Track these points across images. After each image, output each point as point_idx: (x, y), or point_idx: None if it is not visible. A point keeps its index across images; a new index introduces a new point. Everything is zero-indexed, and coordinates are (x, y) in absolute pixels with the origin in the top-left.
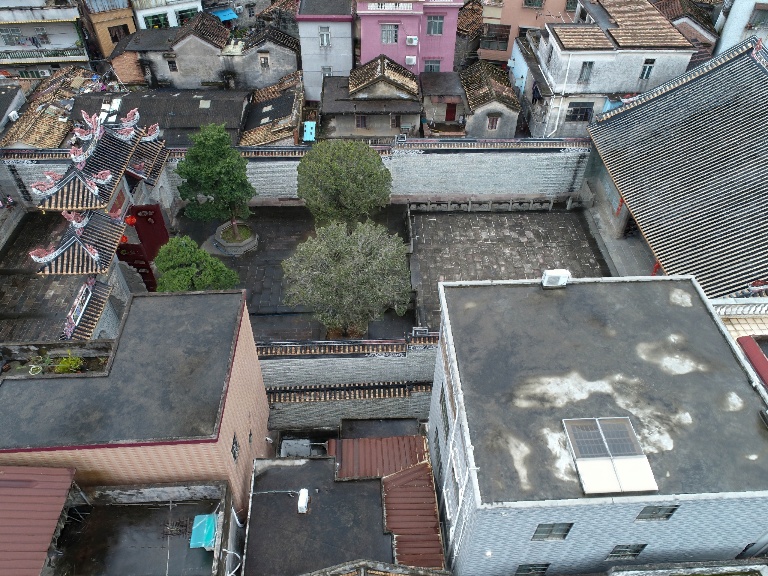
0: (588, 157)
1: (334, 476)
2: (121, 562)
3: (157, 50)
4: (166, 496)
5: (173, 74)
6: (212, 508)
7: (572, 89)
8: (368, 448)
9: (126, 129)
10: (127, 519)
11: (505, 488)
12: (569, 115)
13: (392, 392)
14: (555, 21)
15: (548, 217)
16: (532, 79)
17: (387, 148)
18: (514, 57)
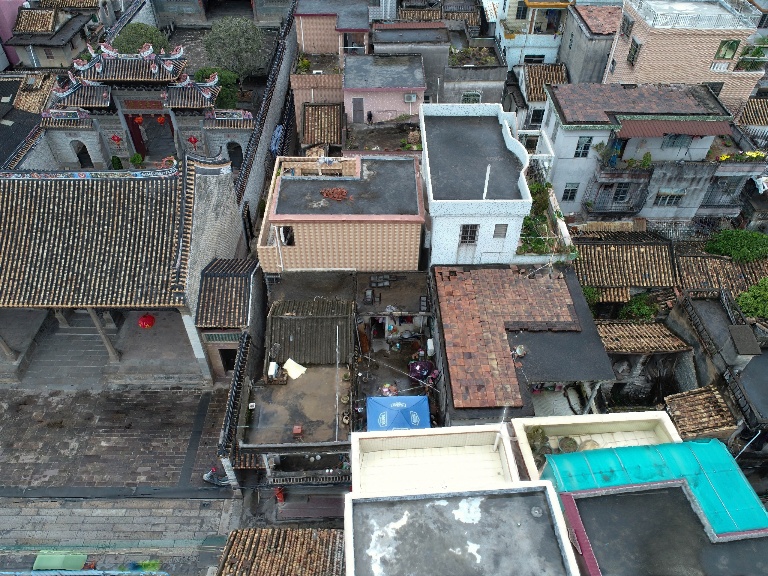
0: (152, 0)
1: None
2: None
3: None
4: None
5: None
6: None
7: None
8: None
9: None
10: None
11: None
12: None
13: None
14: None
15: (176, 37)
16: None
17: (108, 43)
18: None
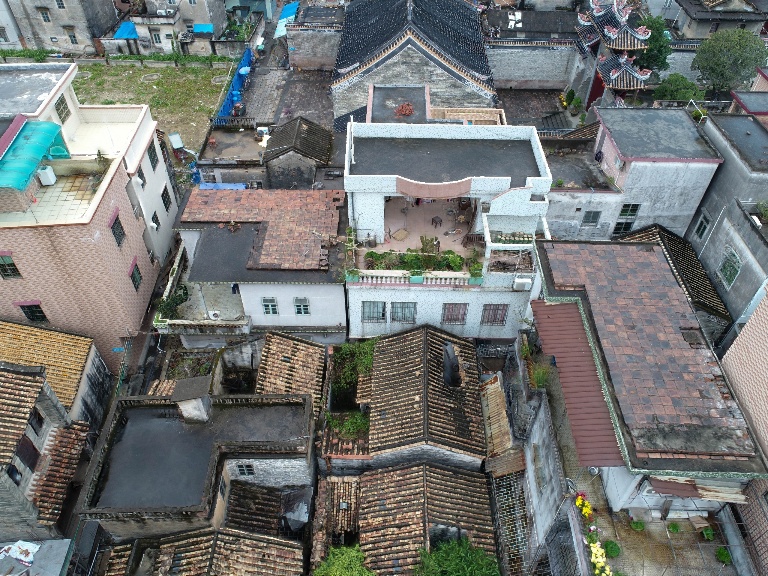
0: None
1: None
2: None
3: None
4: None
5: (537, 0)
6: None
7: None
8: None
9: (627, 8)
10: None
11: None
12: None
13: None
14: None
15: None
16: None
17: None
18: None
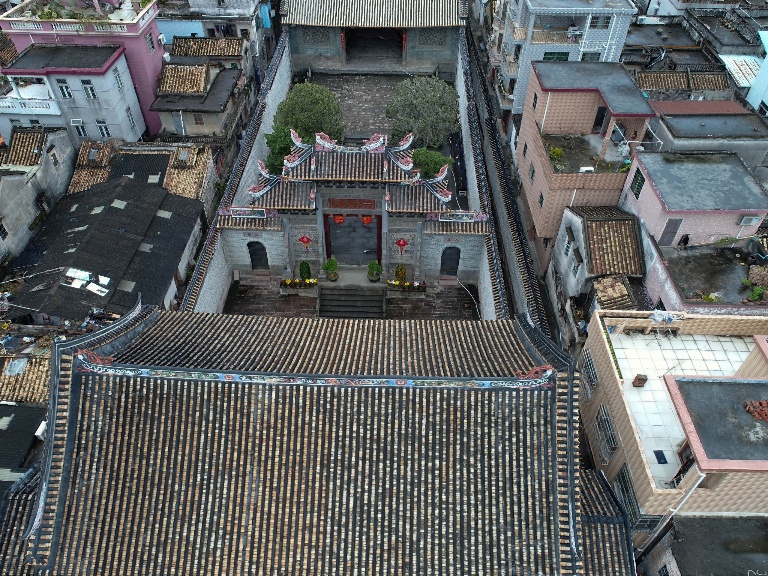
0: None
1: None
2: None
3: None
4: None
5: (7, 242)
6: None
7: (253, 9)
8: None
9: None
10: None
11: (627, 7)
12: None
13: None
14: None
15: None
16: (204, 29)
17: None
18: None
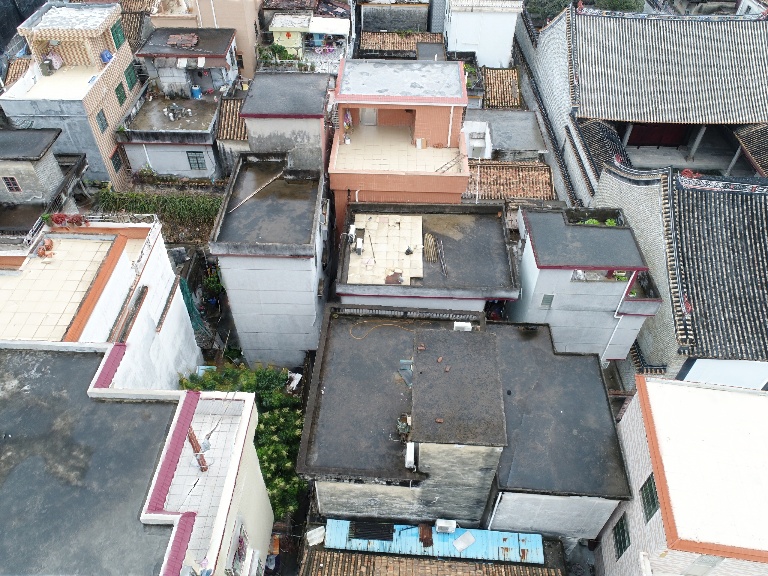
0: None
1: None
2: None
3: None
4: None
5: None
6: None
7: None
8: None
9: None
10: None
11: None
12: None
13: None
14: None
15: None
16: None
17: None
18: None
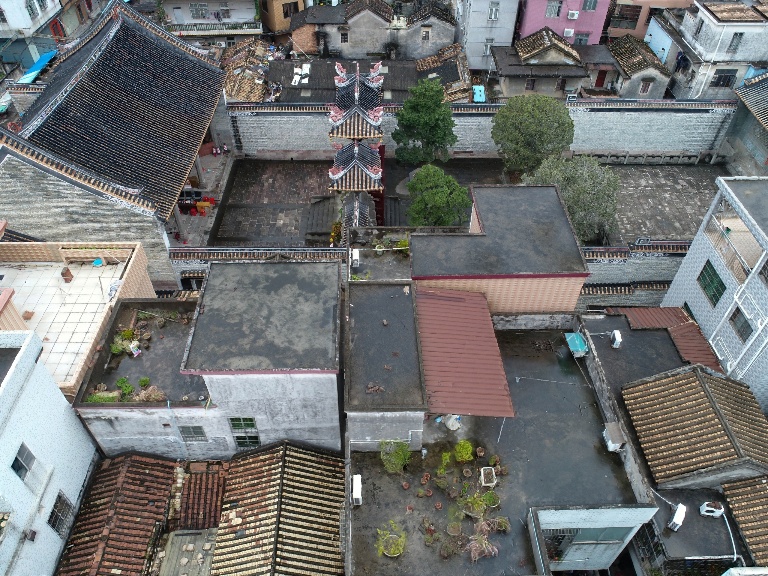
0: (732, 117)
1: (630, 326)
2: (513, 364)
3: (334, 23)
4: (531, 324)
5: (343, 45)
6: (563, 335)
7: (720, 57)
8: (641, 313)
9: (377, 78)
10: (504, 339)
11: None
12: (713, 81)
13: (619, 290)
14: (684, 2)
15: (695, 170)
16: (674, 51)
17: None
18: (651, 33)
